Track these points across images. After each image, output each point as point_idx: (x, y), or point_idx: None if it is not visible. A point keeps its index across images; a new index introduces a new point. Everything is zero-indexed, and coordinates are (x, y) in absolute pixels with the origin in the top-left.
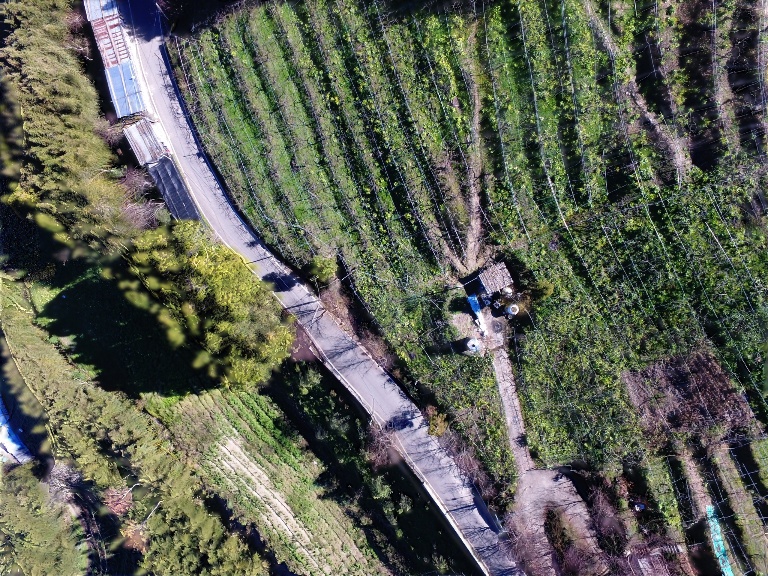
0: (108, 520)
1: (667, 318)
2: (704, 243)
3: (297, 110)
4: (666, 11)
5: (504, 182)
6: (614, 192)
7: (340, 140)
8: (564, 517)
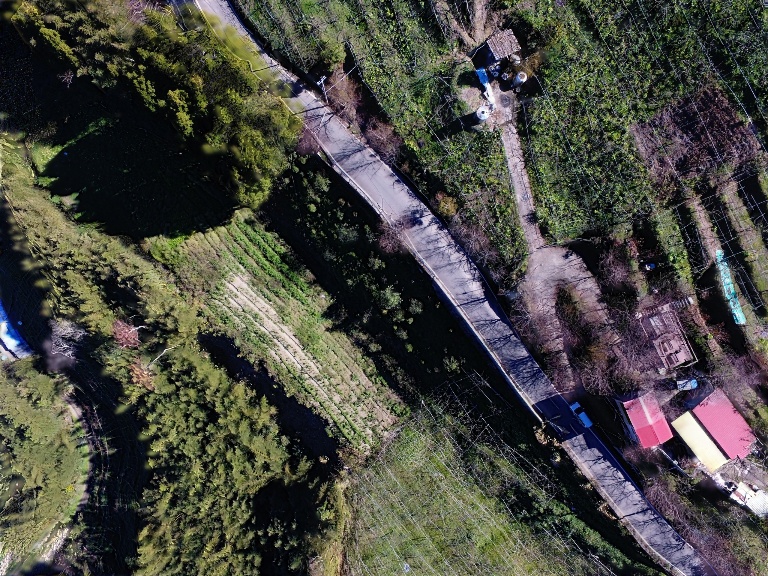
0: (110, 413)
1: (674, 57)
2: None
3: None
4: None
5: None
6: None
7: None
8: (575, 292)
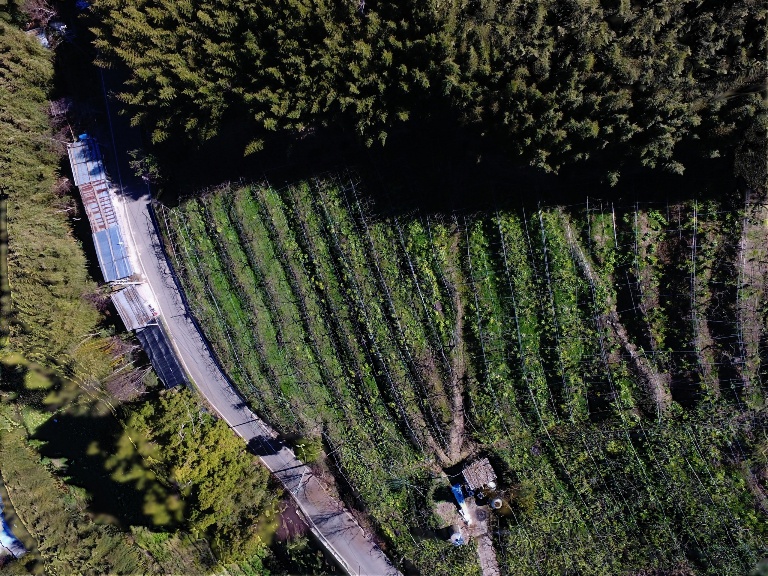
0: None
1: (649, 535)
2: (684, 477)
3: (282, 288)
4: (646, 249)
5: (486, 388)
6: (595, 414)
7: (325, 321)
8: None
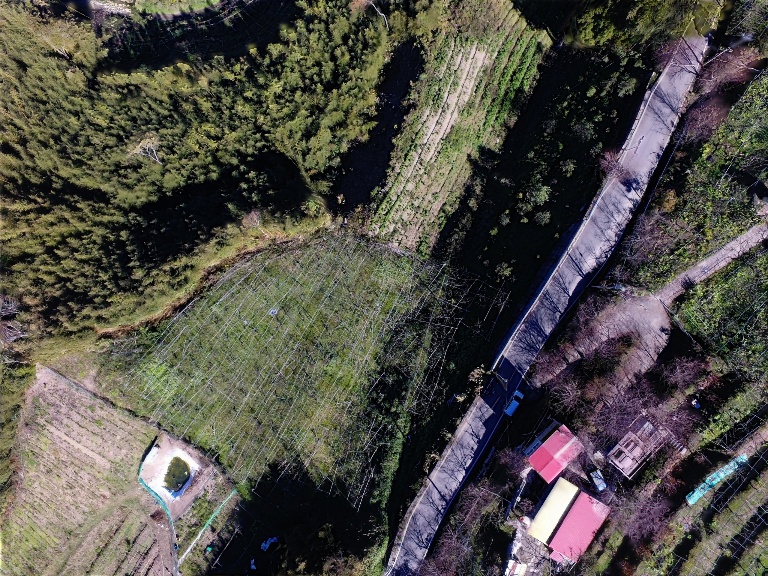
0: (267, 6)
1: None
2: None
3: None
4: None
5: None
6: None
7: None
8: (634, 350)
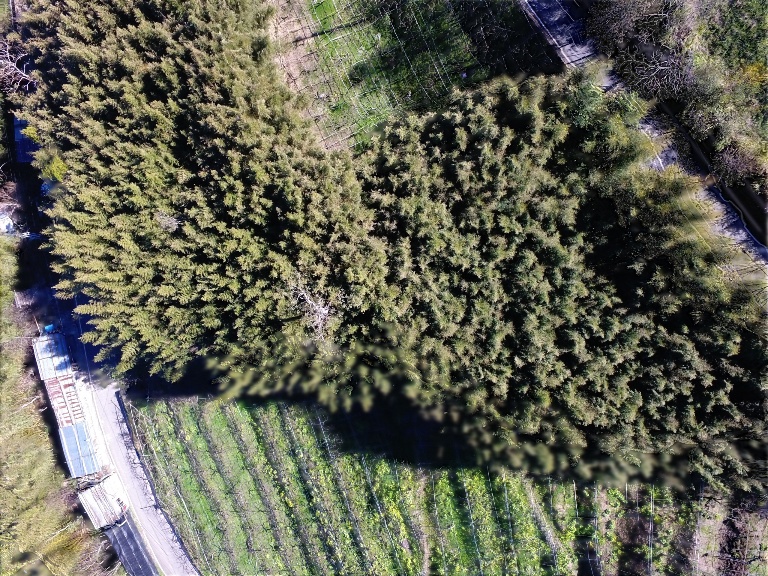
0: None
1: None
2: None
3: (252, 497)
4: (605, 525)
5: None
6: None
7: (295, 533)
8: None
